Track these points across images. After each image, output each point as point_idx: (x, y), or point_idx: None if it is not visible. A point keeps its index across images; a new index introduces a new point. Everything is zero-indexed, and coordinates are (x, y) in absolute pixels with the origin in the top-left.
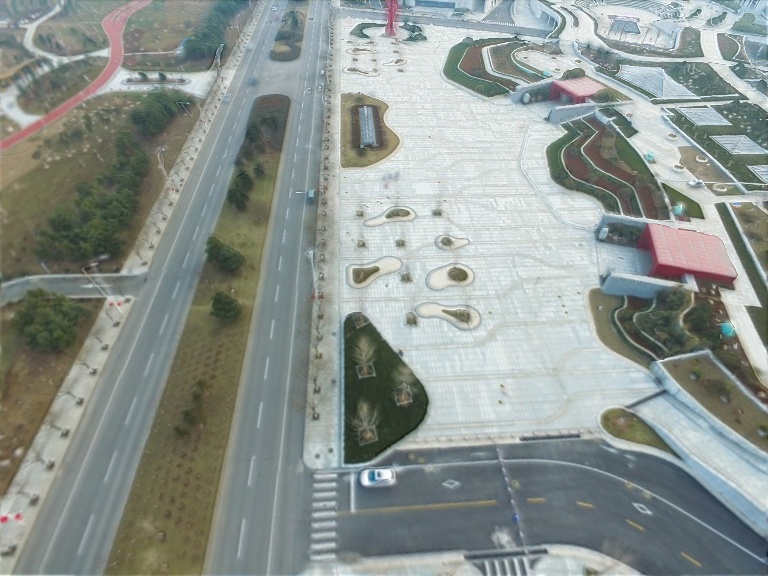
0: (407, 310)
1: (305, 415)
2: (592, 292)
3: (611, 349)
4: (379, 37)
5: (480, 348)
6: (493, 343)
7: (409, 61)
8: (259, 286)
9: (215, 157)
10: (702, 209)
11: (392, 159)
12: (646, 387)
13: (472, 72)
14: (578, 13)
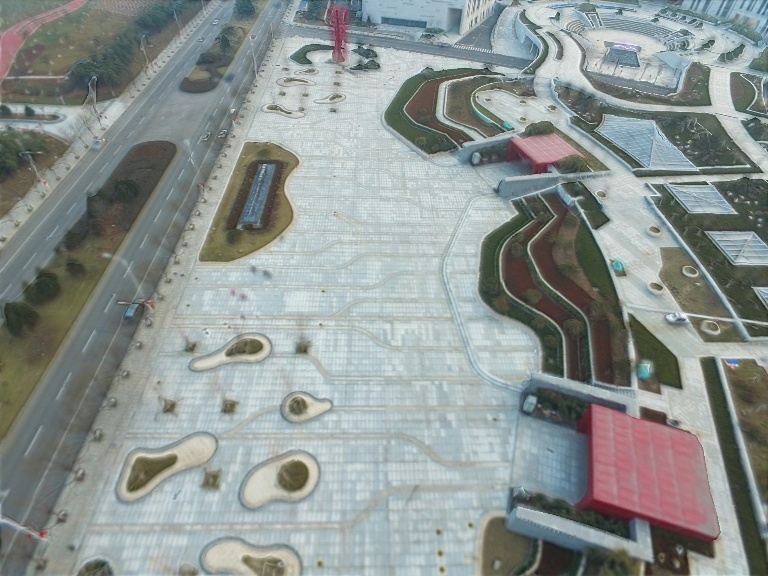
0: (186, 555)
1: None
2: (491, 525)
3: None
4: (324, 63)
5: None
6: None
7: (348, 97)
8: None
9: (37, 237)
10: (680, 368)
11: (272, 249)
12: None
13: (417, 117)
14: (566, 41)
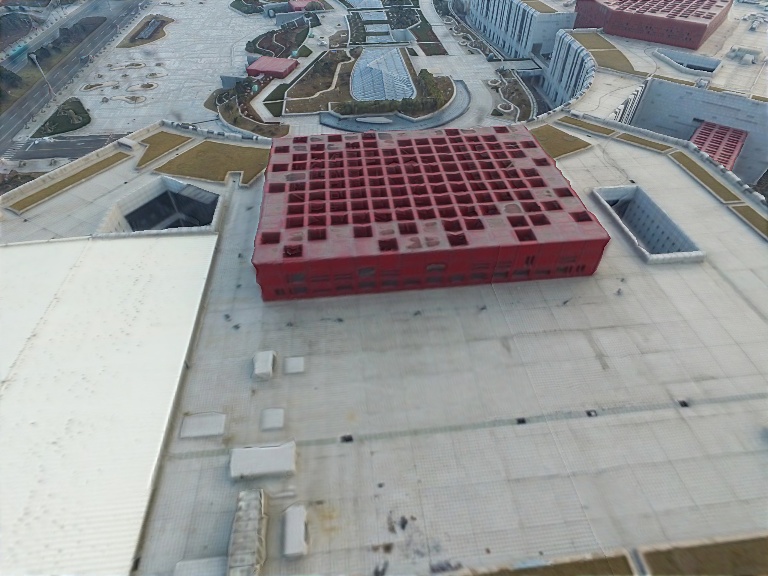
0: None
1: (22, 128)
2: (217, 89)
3: (206, 108)
4: None
5: (135, 109)
6: (144, 107)
7: None
8: (28, 92)
9: (36, 46)
10: (311, 54)
11: (152, 44)
12: (211, 118)
13: (247, 1)
14: None
